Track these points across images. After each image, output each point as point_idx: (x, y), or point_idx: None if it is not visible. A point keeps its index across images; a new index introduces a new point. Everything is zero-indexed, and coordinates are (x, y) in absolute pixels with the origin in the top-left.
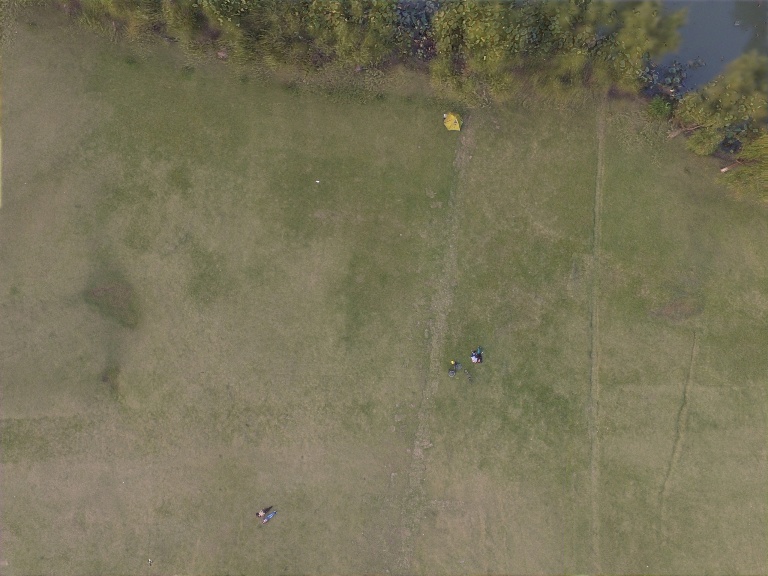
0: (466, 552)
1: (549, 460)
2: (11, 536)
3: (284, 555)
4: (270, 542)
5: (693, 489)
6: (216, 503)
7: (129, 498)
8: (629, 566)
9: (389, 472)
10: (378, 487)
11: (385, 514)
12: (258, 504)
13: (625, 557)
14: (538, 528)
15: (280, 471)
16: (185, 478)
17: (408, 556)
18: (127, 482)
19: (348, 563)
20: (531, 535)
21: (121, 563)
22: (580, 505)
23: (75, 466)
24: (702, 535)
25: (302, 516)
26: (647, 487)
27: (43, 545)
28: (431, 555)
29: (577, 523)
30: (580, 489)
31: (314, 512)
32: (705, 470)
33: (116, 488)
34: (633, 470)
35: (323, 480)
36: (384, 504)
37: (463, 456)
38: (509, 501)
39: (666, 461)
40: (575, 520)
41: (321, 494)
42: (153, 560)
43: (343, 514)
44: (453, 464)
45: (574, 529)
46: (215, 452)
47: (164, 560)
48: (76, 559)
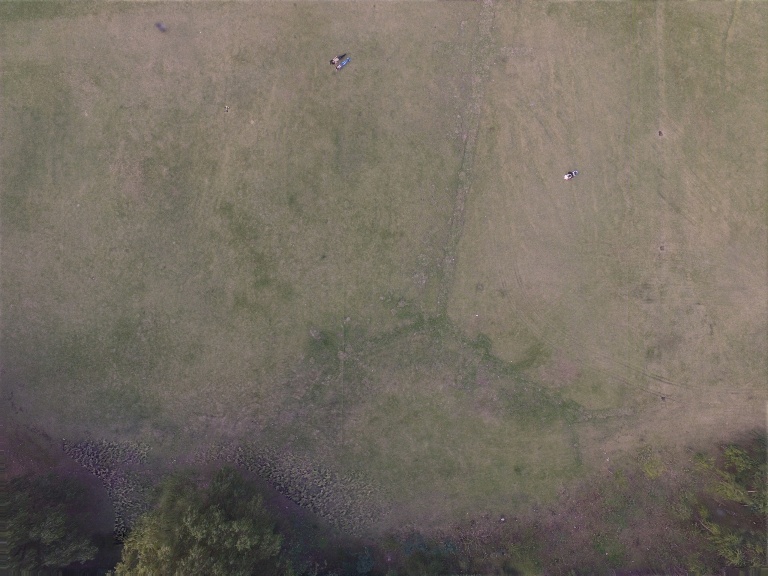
0: (535, 95)
1: (615, 7)
2: (91, 87)
3: (357, 101)
4: (344, 89)
5: (756, 35)
6: (291, 50)
7: (206, 47)
8: (694, 111)
9: (459, 20)
10: (448, 35)
11: (455, 61)
12: (332, 52)
13: (690, 102)
14: (605, 73)
15: (353, 19)
16: (261, 26)
17: (478, 102)
18: (204, 32)
19: (420, 109)
20: (598, 79)
21: (198, 111)
22: (646, 52)
23: (153, 17)
24: (765, 80)
25: (375, 64)
26: (711, 34)
27: (122, 94)
28: (501, 99)
29: (643, 69)
30: (645, 37)
31: (386, 60)
32: (767, 16)
33: (193, 38)
34: (697, 17)
35: (395, 28)
36: (454, 52)
37: (531, 2)
38: (577, 46)
39: (729, 8)
40: (641, 66)
41: (393, 42)
42: (230, 106)
43: (415, 62)
44: (522, 10)
45: (640, 75)
46: (290, 1)
47: (240, 106)
48: (154, 108)
